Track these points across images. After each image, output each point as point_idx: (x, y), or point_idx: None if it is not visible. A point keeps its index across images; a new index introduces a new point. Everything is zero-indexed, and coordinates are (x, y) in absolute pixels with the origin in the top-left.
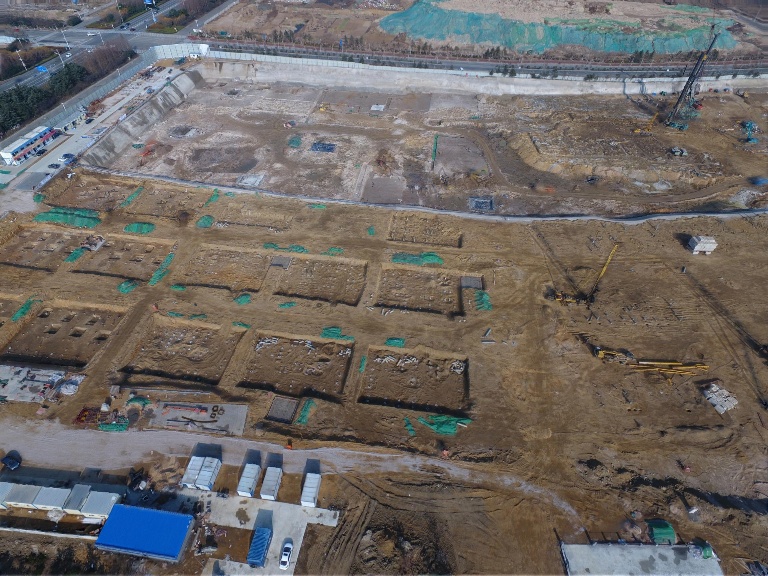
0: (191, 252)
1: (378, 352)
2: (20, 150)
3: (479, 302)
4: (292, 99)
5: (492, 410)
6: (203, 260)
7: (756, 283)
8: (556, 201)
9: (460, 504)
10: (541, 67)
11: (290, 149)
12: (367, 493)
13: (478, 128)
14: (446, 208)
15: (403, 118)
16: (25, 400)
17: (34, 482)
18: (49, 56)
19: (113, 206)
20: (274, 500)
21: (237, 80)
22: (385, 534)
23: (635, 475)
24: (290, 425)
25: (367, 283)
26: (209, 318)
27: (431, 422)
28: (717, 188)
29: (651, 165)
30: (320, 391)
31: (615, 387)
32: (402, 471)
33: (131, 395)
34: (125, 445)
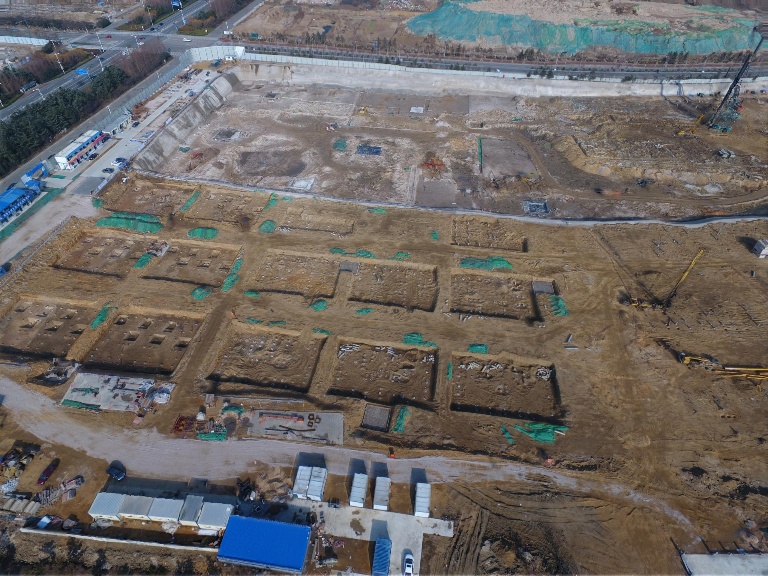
0: (259, 257)
1: (461, 358)
2: (74, 154)
3: (555, 307)
4: (331, 101)
5: (587, 417)
6: (271, 265)
7: None
8: (610, 204)
9: (573, 513)
10: (577, 69)
11: (336, 152)
12: (478, 503)
13: (520, 130)
14: (501, 212)
15: (444, 120)
16: (119, 409)
17: (143, 493)
18: (85, 59)
19: (172, 211)
20: (386, 510)
21: (273, 82)
22: (504, 545)
23: (740, 483)
24: (387, 433)
25: (440, 288)
26: (288, 325)
27: (528, 430)
28: None
29: (700, 167)
30: (410, 398)
31: (705, 393)
32: (509, 480)
33: (225, 404)
34: (227, 455)
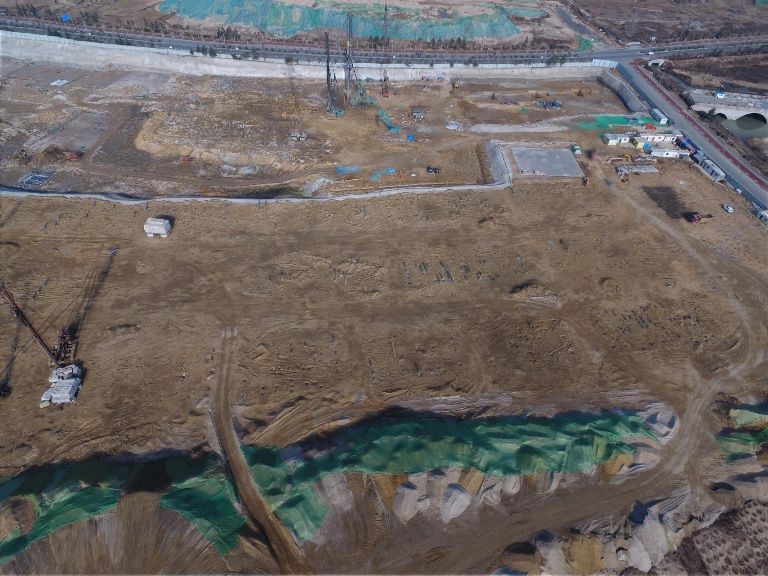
0: None
1: None
2: None
3: None
4: None
5: None
6: None
7: (172, 268)
8: (114, 180)
9: None
10: (259, 49)
11: None
12: None
13: (136, 106)
14: None
15: (67, 93)
16: None
17: None
18: None
19: None
20: None
21: None
22: None
23: None
24: None
25: None
26: None
27: None
28: (298, 175)
29: (254, 149)
30: None
31: None
32: None
33: None
34: None
